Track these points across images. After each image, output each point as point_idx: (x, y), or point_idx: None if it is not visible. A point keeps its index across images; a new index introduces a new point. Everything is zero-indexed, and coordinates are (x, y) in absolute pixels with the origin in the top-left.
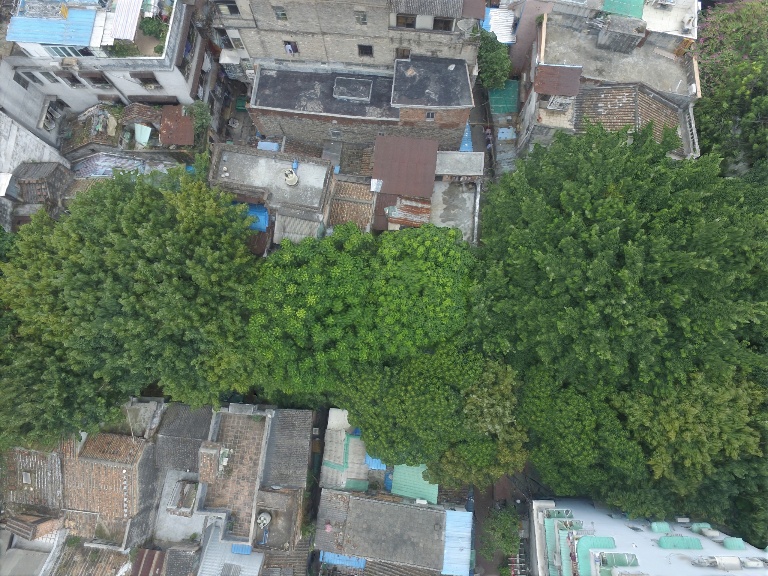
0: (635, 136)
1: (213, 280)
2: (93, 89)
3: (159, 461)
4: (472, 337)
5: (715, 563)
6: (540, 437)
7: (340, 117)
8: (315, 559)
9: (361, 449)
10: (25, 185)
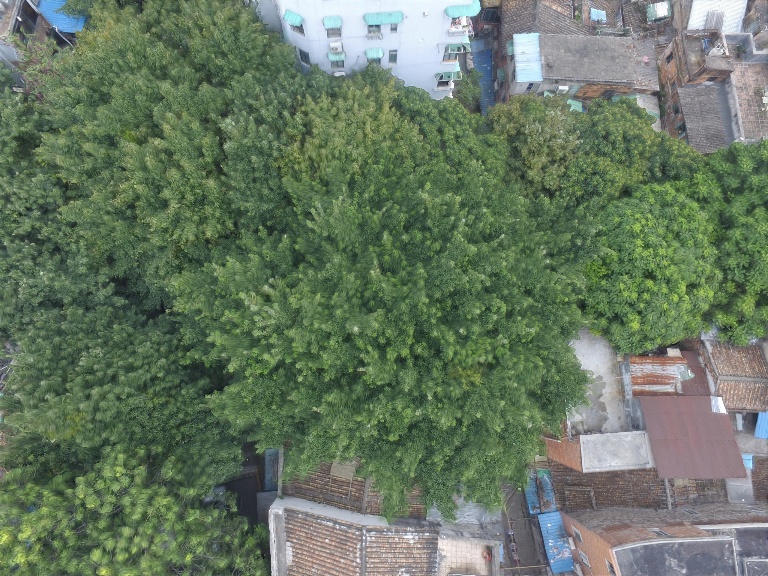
0: None
1: None
2: None
3: None
4: None
5: None
6: None
7: None
8: None
9: None
10: None
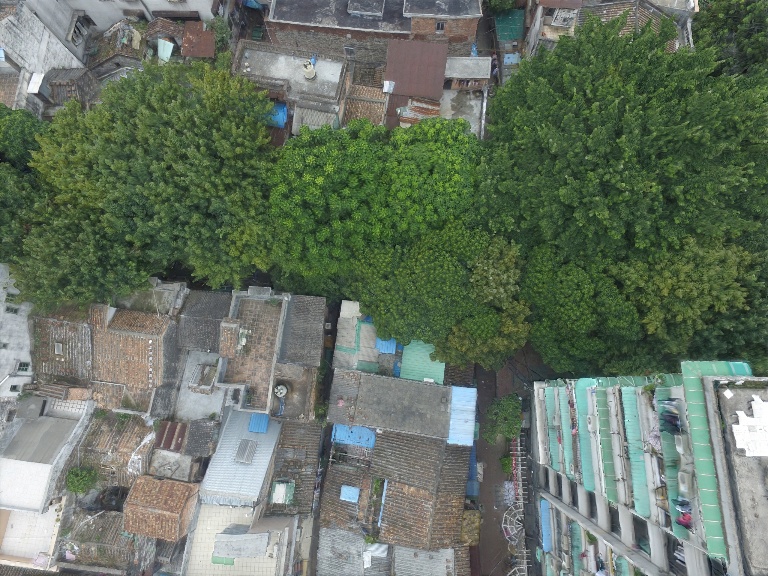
0: (635, 35)
1: (237, 152)
2: (119, 3)
3: (181, 341)
4: (479, 216)
5: None
6: (542, 315)
7: (354, 30)
8: (325, 453)
9: (372, 335)
10: (56, 87)
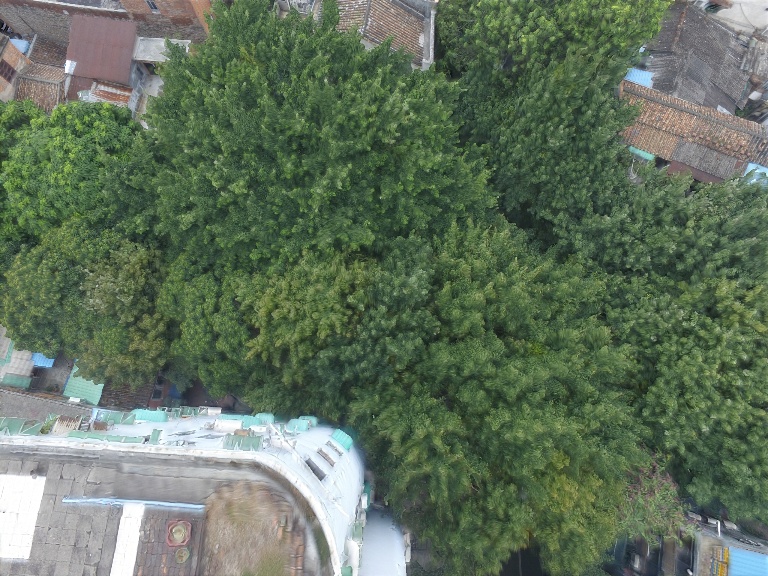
0: (324, 21)
1: None
2: None
3: None
4: (109, 214)
5: (213, 425)
6: None
7: (66, 5)
8: None
9: None
10: None
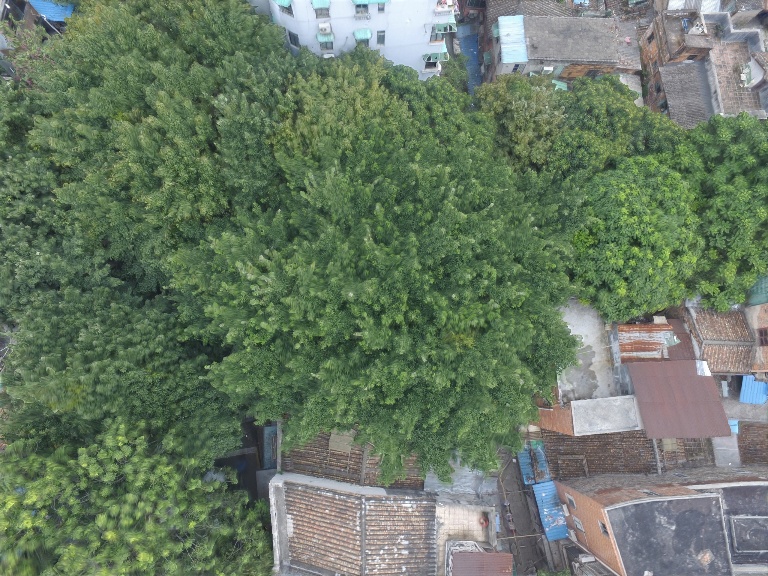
0: None
1: None
2: None
3: None
4: None
5: None
6: None
7: (763, 481)
8: None
9: None
10: None
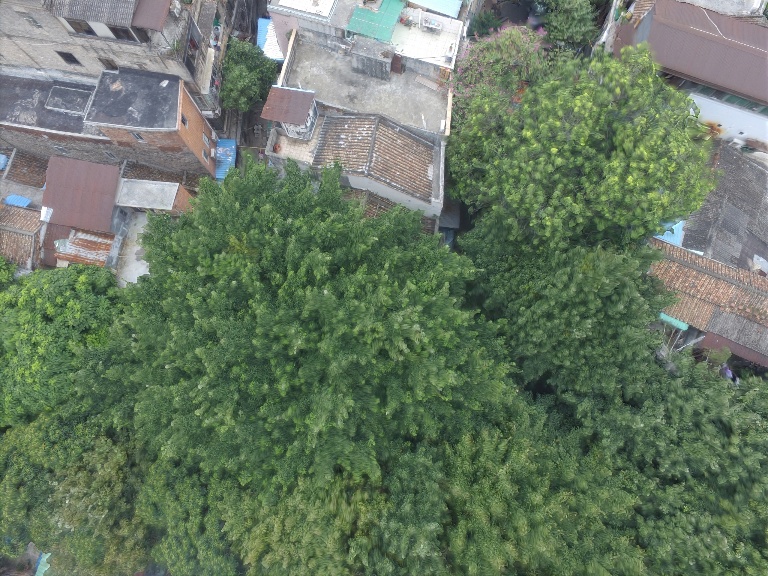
0: None
1: None
2: None
3: None
4: (83, 407)
5: None
6: None
7: (45, 131)
8: None
9: None
10: None
